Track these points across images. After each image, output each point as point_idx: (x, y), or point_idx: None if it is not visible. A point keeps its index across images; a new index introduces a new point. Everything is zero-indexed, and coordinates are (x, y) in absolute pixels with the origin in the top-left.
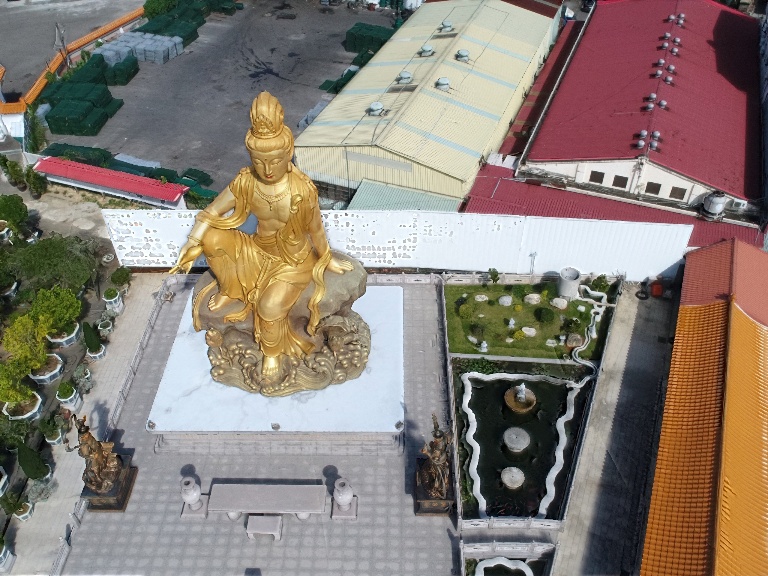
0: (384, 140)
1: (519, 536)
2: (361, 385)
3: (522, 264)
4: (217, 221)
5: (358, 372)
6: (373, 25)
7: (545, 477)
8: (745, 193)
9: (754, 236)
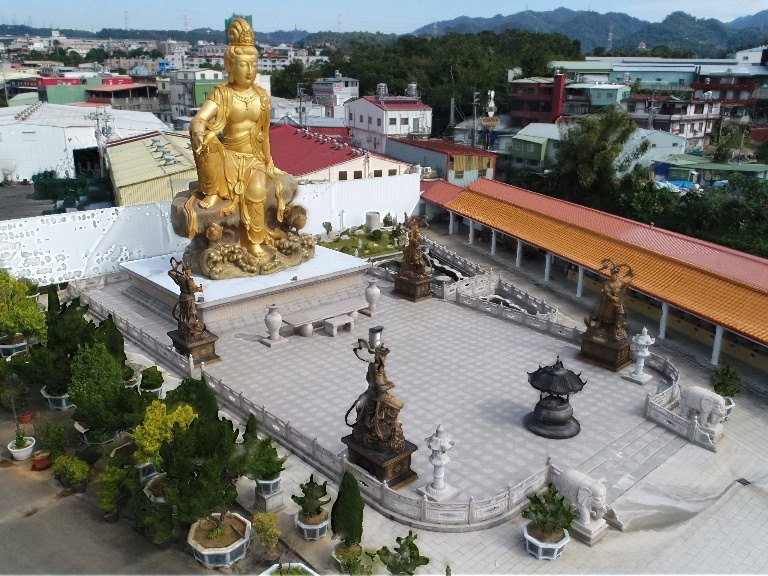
0: None
1: None
2: (321, 259)
3: (335, 224)
4: (208, 124)
5: (313, 253)
6: (55, 179)
7: None
8: None
9: None
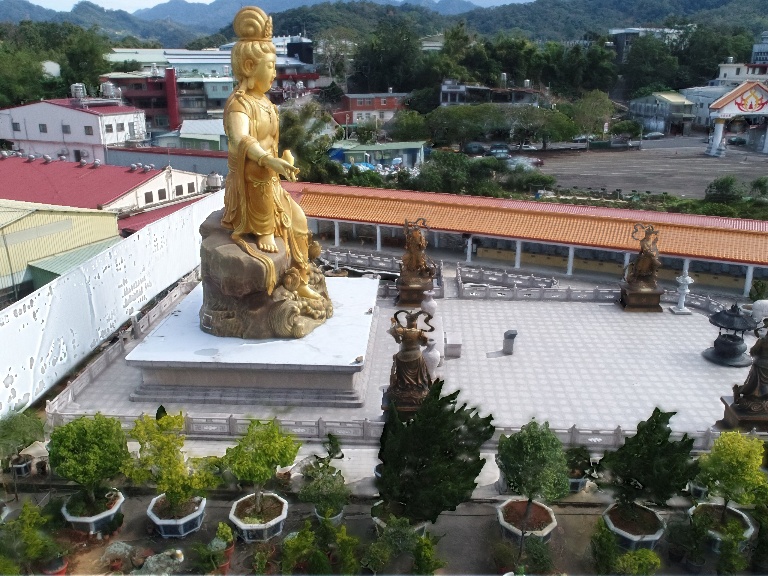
0: None
1: (448, 282)
2: (328, 288)
3: None
4: None
5: None
6: None
7: None
8: None
9: None
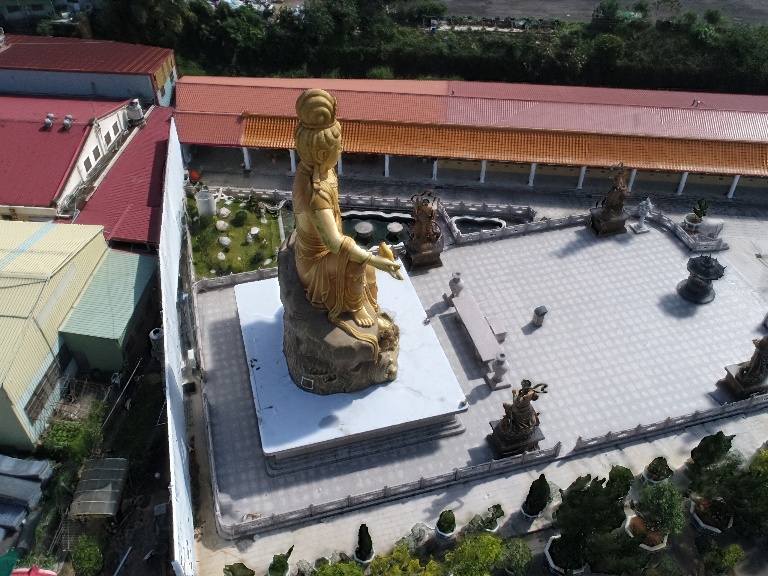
0: (39, 273)
1: None
2: None
3: None
4: None
5: None
6: None
7: (383, 223)
8: (120, 101)
9: (163, 110)
